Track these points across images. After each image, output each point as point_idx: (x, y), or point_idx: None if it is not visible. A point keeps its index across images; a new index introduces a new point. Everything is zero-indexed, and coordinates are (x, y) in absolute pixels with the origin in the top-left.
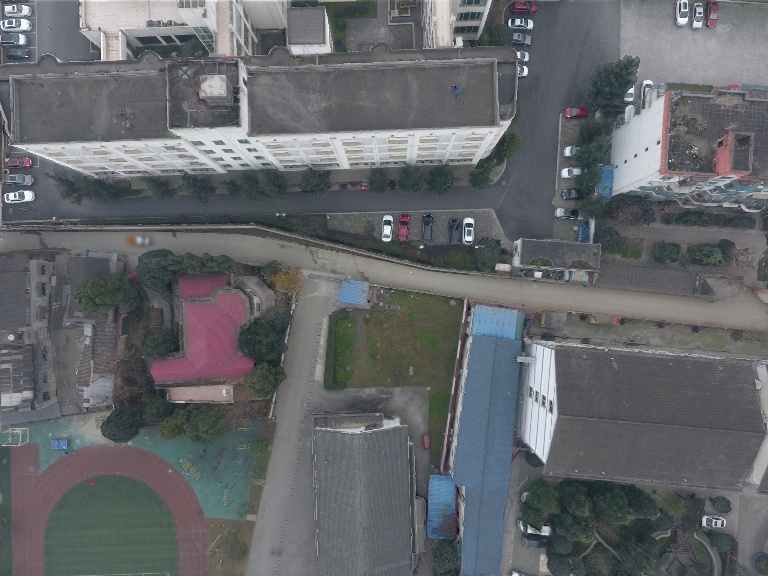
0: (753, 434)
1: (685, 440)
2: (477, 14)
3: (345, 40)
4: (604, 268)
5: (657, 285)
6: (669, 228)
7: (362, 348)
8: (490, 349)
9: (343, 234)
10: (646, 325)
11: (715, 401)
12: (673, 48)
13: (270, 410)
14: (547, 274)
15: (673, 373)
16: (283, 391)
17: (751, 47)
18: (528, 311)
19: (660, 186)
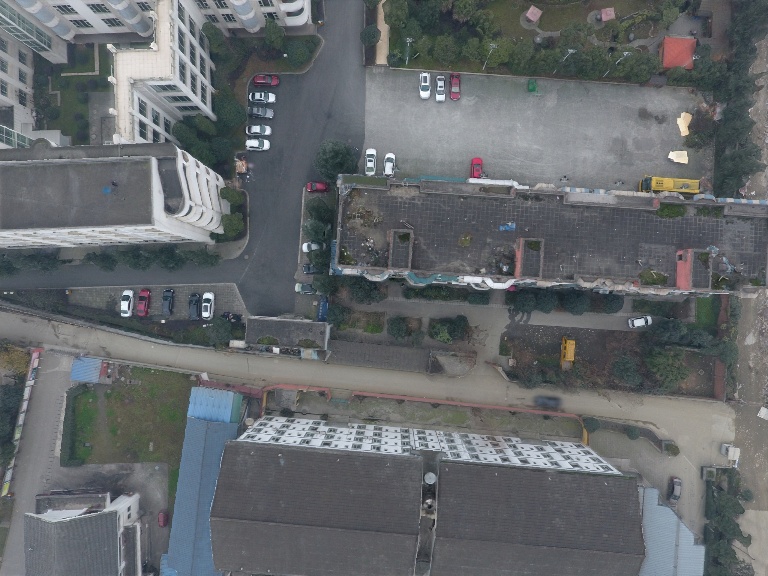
0: (404, 536)
1: (340, 541)
2: (185, 97)
3: (88, 113)
4: (337, 345)
5: (390, 362)
6: (411, 302)
7: (103, 423)
8: (201, 433)
9: (82, 309)
10: (386, 400)
11: (375, 500)
12: (418, 121)
13: (2, 488)
14: (286, 349)
15: (339, 470)
16: (22, 467)
17: (496, 119)
18: (253, 391)
19: (353, 274)
